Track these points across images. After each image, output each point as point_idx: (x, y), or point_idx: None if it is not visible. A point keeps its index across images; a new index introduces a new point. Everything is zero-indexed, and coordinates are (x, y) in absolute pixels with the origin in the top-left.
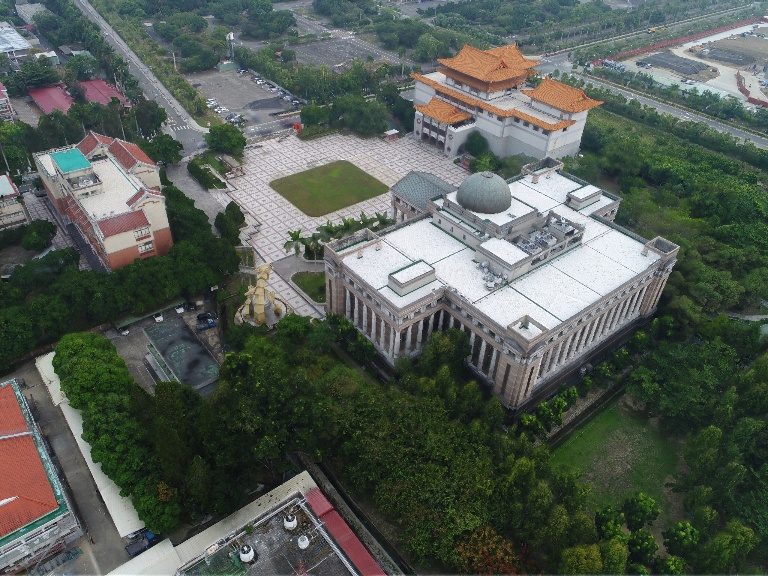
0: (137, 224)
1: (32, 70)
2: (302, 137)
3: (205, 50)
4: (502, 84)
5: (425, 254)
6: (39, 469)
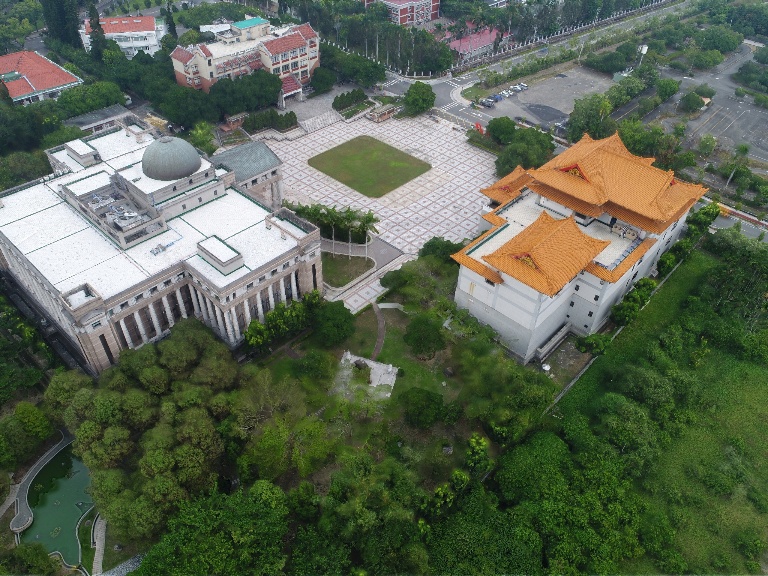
0: (184, 60)
1: (475, 4)
2: (470, 138)
3: (616, 53)
4: (562, 196)
5: (126, 162)
6: None
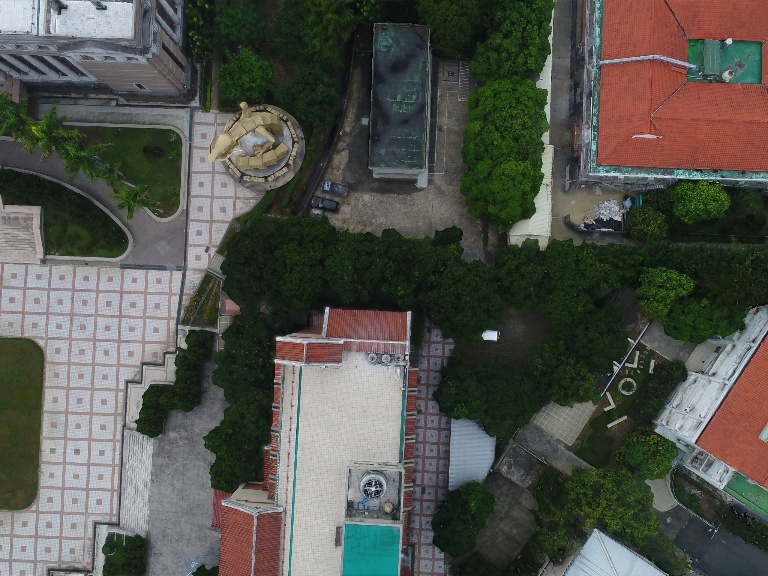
0: (348, 315)
1: None
2: None
3: None
4: None
5: None
6: (609, 7)
